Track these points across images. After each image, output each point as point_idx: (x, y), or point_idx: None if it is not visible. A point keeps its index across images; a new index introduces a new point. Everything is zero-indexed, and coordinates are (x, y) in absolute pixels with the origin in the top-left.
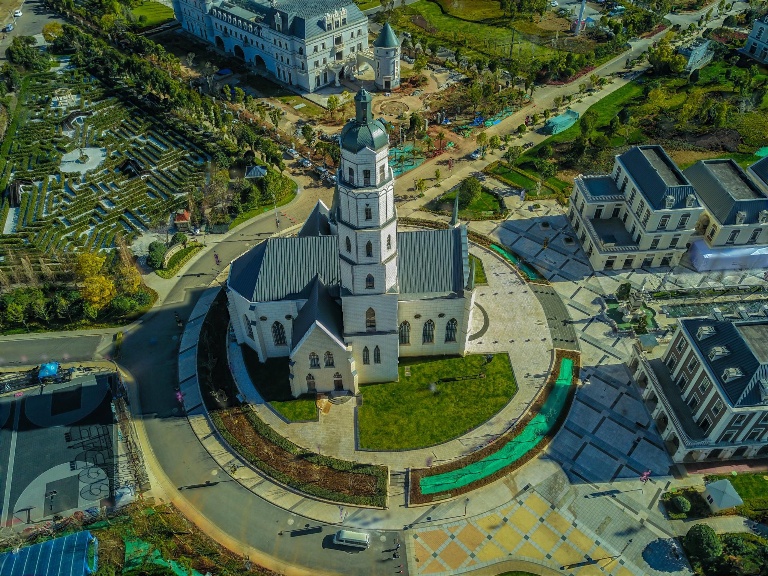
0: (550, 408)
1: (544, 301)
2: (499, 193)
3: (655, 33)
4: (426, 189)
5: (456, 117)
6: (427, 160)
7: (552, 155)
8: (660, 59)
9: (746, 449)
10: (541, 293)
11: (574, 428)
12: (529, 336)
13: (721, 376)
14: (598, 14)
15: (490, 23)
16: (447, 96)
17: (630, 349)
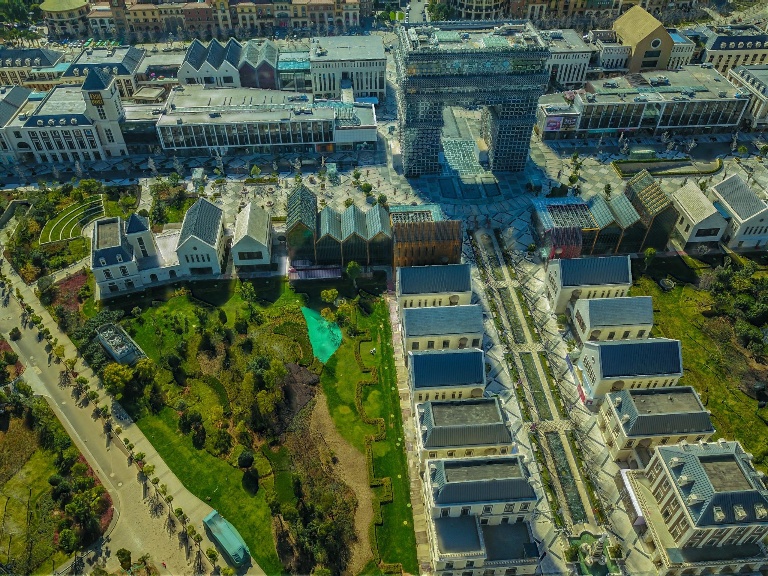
0: None
1: None
2: None
3: None
4: None
5: None
6: None
7: (305, 569)
8: (125, 381)
9: None
10: None
11: None
12: None
13: (757, 519)
14: None
15: None
16: None
17: (641, 569)
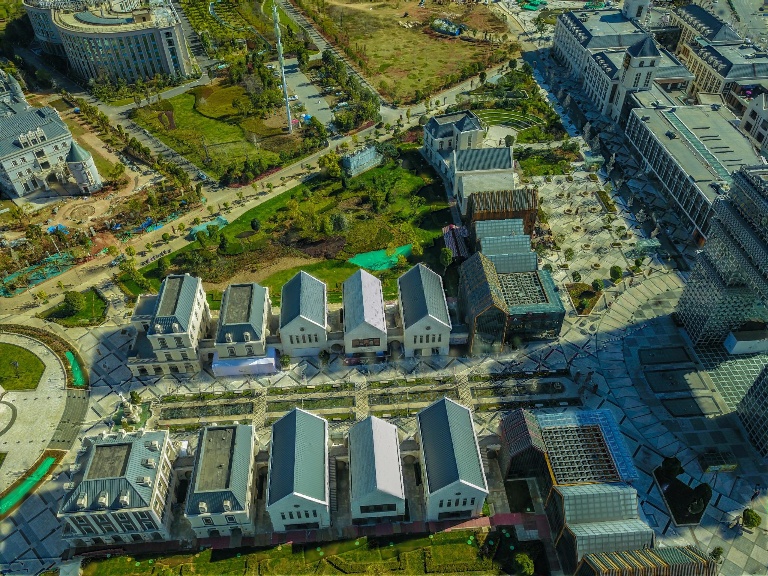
0: (8, 501)
1: (70, 405)
2: (111, 300)
3: (359, 131)
4: (55, 296)
5: (127, 222)
6: (74, 267)
7: (179, 262)
8: (324, 165)
9: (120, 537)
10: (73, 398)
11: (17, 518)
12: (35, 437)
13: None
14: (326, 109)
15: (224, 120)
16: (134, 200)
17: None
